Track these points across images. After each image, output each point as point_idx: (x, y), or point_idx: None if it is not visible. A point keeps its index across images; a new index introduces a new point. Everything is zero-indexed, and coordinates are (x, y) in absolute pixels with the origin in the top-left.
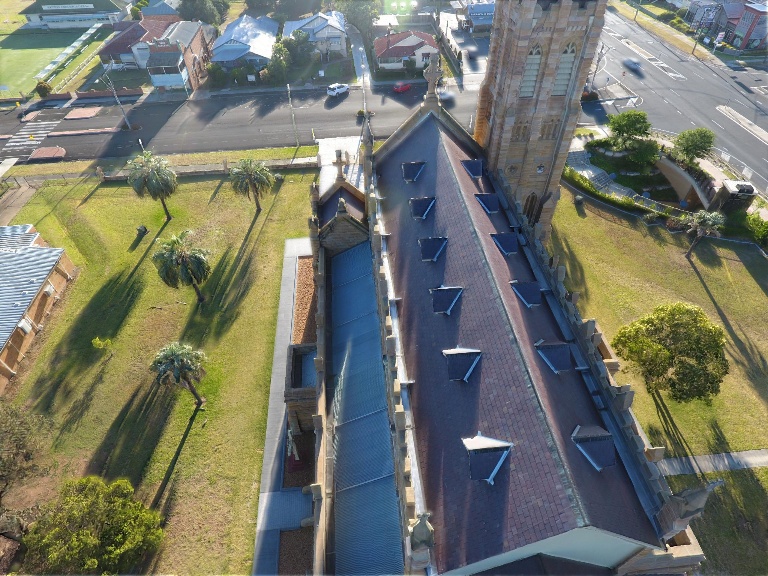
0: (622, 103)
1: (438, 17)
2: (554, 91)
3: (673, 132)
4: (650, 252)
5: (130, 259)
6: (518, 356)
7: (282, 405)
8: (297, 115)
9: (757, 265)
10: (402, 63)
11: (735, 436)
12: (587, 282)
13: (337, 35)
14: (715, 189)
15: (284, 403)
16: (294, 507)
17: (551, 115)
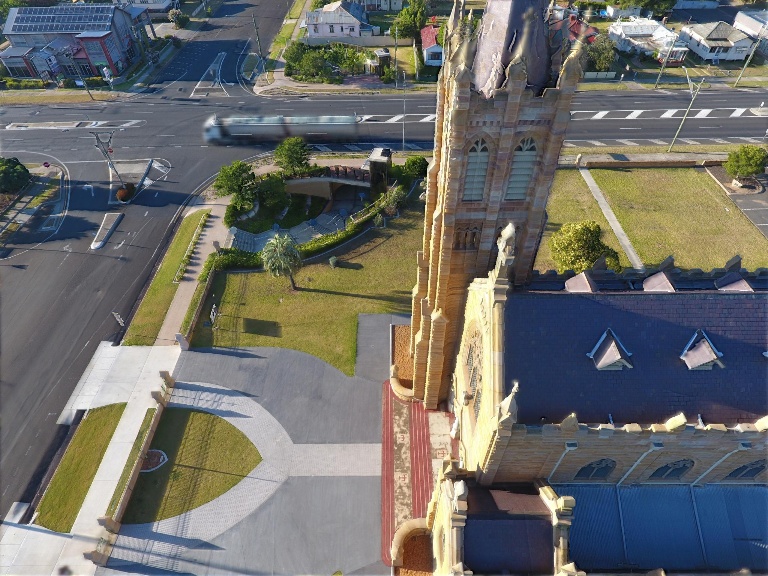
0: (157, 174)
1: None
2: None
3: None
4: None
5: None
6: None
7: None
8: None
9: None
10: None
11: (619, 261)
12: None
13: None
14: (365, 169)
15: None
16: None
17: None
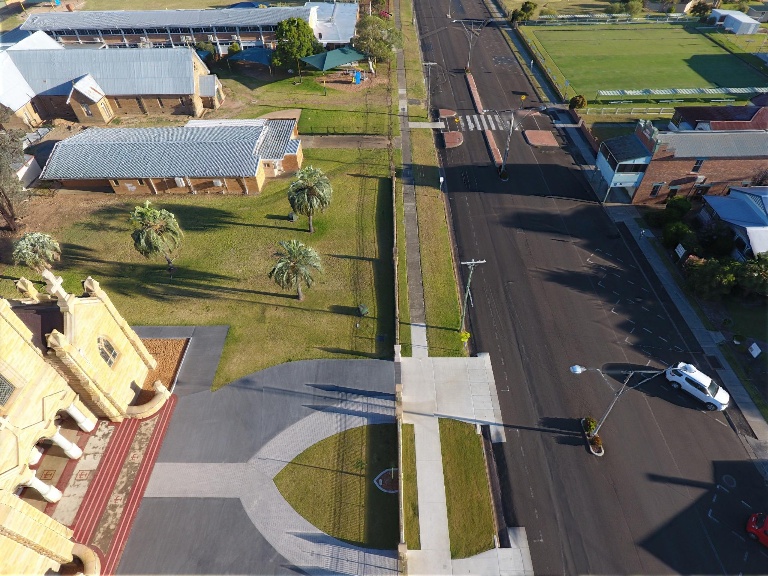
0: None
1: None
2: None
3: None
4: None
5: (255, 218)
6: None
7: None
8: (569, 323)
9: None
10: None
11: None
12: None
13: None
14: None
15: None
16: None
17: None
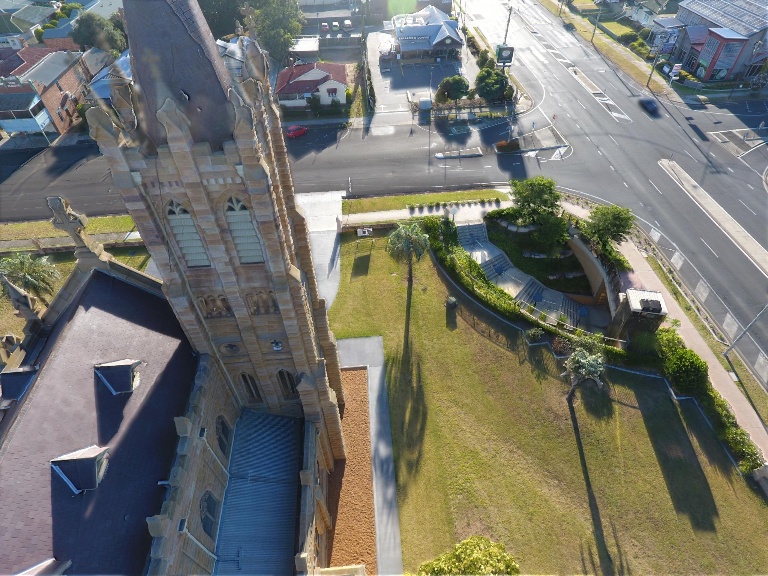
0: (547, 154)
1: (364, 41)
2: (244, 257)
3: (598, 197)
4: (522, 390)
5: None
6: None
7: None
8: None
9: (660, 416)
10: (305, 100)
11: None
12: (425, 441)
13: (237, 66)
14: (620, 297)
15: None
16: None
17: (254, 287)
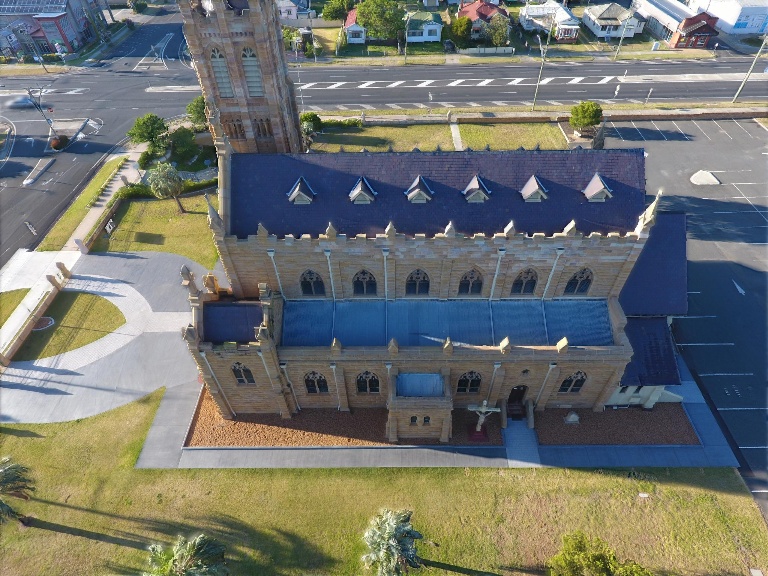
0: (90, 130)
1: None
2: None
3: None
4: None
5: None
6: (550, 152)
7: (417, 452)
8: None
9: (329, 139)
10: None
11: None
12: None
13: None
14: None
15: (415, 450)
16: (518, 435)
17: None
